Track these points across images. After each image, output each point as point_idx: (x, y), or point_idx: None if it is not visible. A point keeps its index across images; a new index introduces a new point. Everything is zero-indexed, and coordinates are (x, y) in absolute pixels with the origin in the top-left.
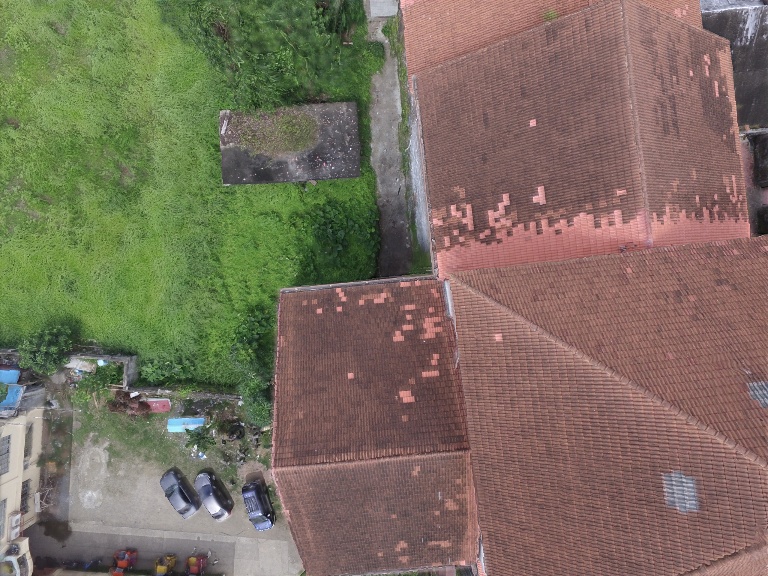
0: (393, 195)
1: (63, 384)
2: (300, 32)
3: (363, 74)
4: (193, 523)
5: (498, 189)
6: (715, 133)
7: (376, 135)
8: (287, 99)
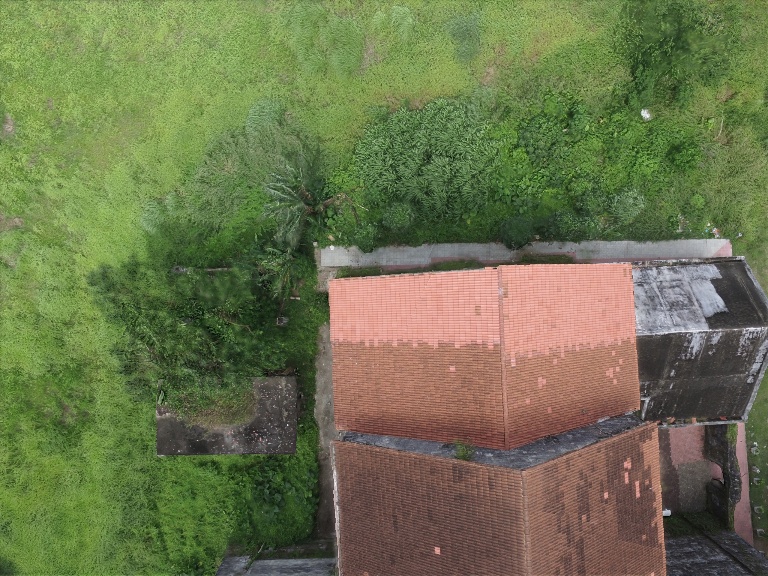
0: None
1: None
2: (248, 281)
3: (310, 328)
4: None
5: None
6: (632, 541)
7: (321, 387)
8: (226, 371)
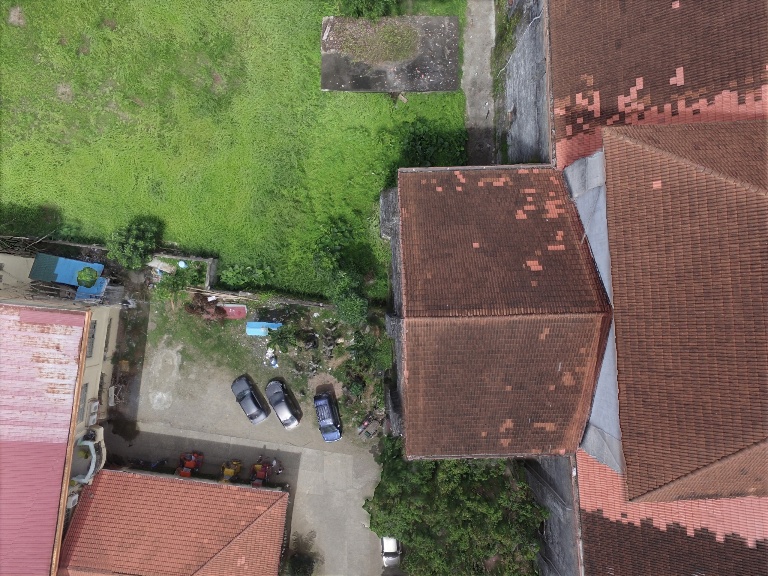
0: (481, 119)
1: (142, 284)
2: None
3: None
4: (260, 431)
5: (631, 73)
6: None
7: (468, 58)
8: (390, 10)
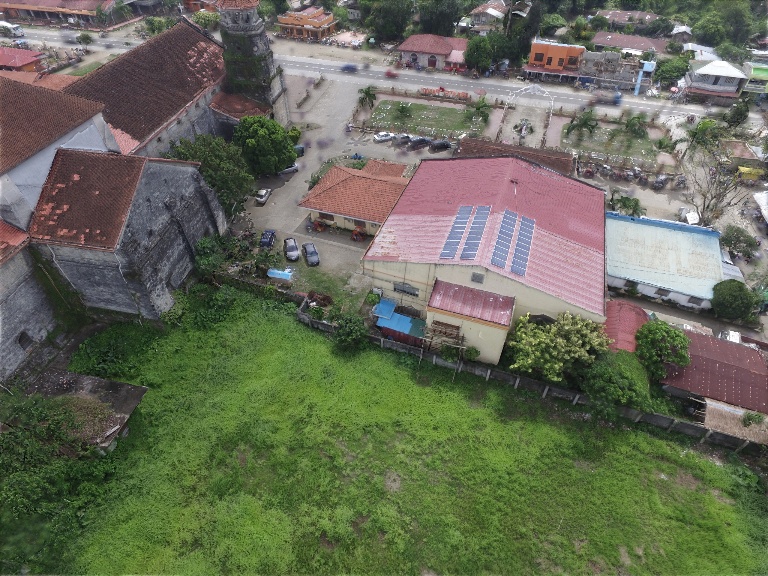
0: None
1: None
2: None
3: None
4: None
5: None
6: None
7: None
8: None
